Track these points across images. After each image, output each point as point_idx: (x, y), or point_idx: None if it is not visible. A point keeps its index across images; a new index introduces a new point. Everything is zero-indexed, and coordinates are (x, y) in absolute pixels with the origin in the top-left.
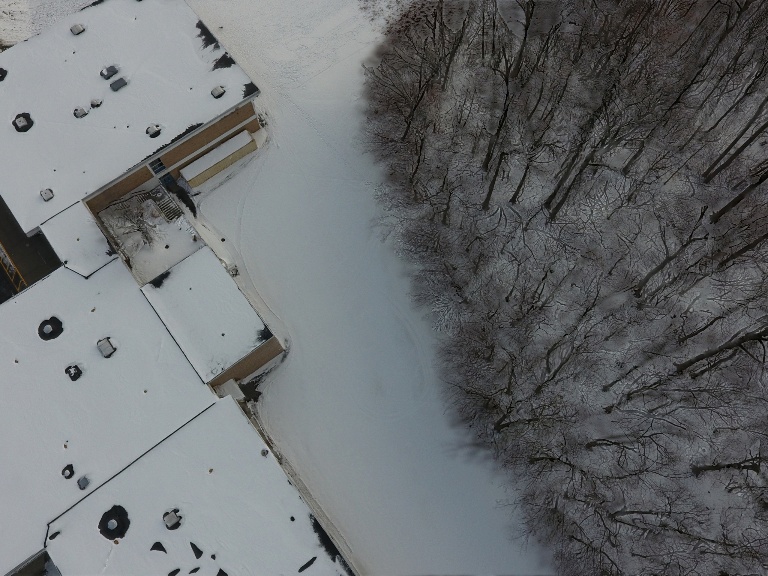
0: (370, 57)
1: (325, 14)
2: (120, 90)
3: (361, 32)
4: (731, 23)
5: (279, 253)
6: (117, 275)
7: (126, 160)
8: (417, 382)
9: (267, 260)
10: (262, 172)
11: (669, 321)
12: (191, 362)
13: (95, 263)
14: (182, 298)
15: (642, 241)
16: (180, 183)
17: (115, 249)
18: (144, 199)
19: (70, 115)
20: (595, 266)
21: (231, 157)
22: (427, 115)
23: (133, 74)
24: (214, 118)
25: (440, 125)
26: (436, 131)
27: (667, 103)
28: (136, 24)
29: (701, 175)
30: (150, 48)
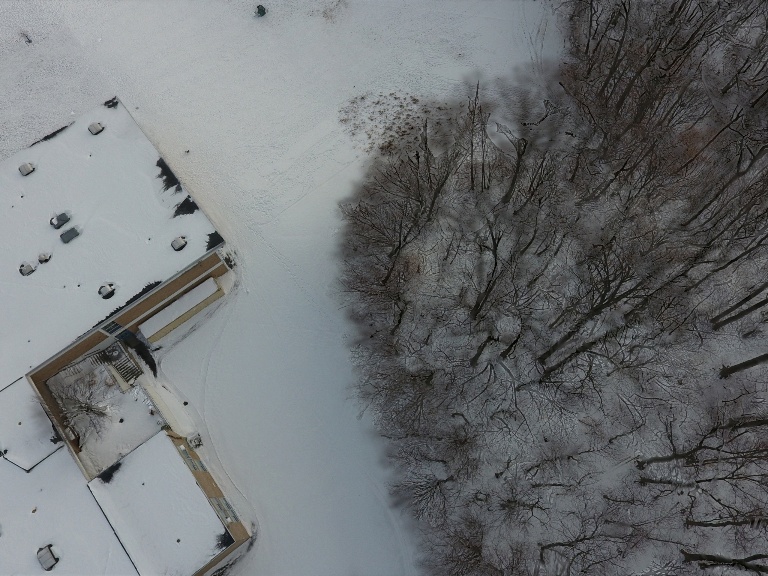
0: (350, 181)
1: (302, 130)
2: (71, 242)
3: (341, 150)
4: (743, 167)
5: (247, 419)
6: (62, 467)
7: (76, 326)
8: (397, 575)
9: (233, 427)
10: (229, 322)
11: (676, 498)
12: (142, 575)
13: (38, 453)
14: (134, 496)
15: (646, 432)
16: (139, 336)
17: (61, 435)
18: (98, 360)
19: (15, 272)
20: (594, 434)
21: (195, 308)
22: (410, 259)
23: (86, 222)
24: (174, 275)
25: (425, 265)
26: (420, 271)
27: (672, 241)
28: (91, 162)
29: (709, 320)
30: (105, 191)
